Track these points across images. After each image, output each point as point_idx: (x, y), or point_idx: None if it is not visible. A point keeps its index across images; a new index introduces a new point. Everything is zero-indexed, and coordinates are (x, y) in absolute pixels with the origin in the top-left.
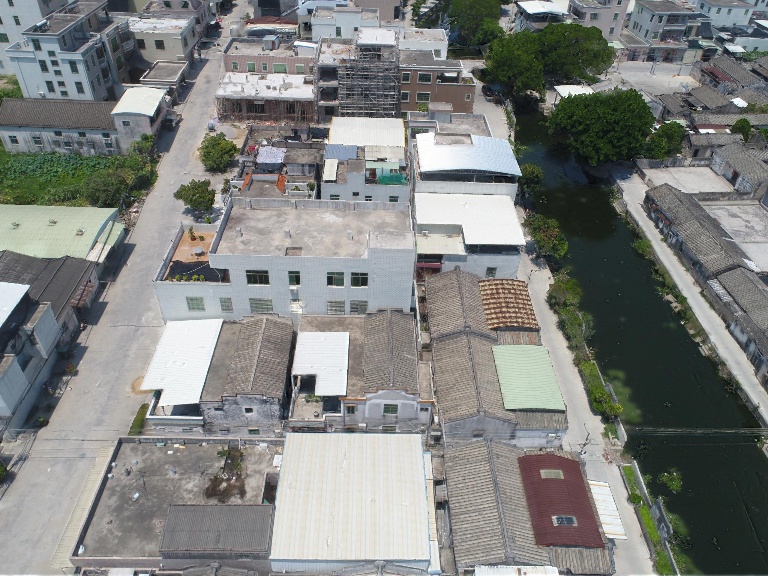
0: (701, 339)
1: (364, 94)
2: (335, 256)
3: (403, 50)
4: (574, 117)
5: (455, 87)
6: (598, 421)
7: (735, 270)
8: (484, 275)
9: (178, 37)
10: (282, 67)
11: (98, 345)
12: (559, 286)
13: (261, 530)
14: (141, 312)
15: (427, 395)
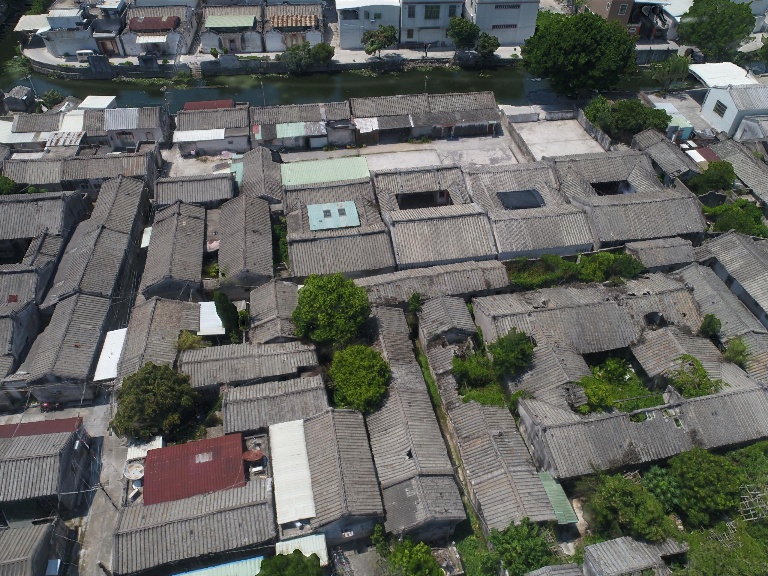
0: None
1: None
2: None
3: None
4: None
5: None
6: None
7: None
8: None
9: None
10: None
11: None
12: (322, 42)
13: None
14: None
15: None
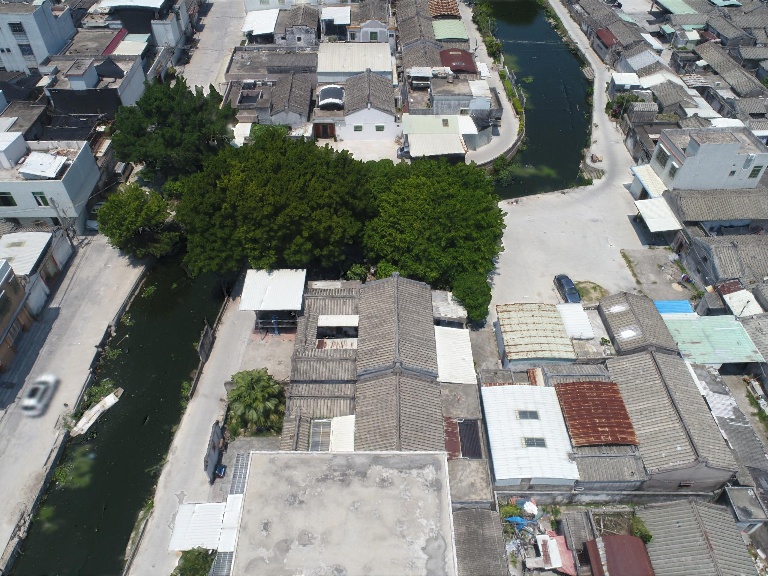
0: (564, 34)
1: None
2: None
3: None
4: None
5: None
6: (491, 59)
7: None
8: None
9: None
10: None
11: (206, 39)
12: (478, 5)
13: (312, 61)
14: (226, 27)
15: (393, 26)
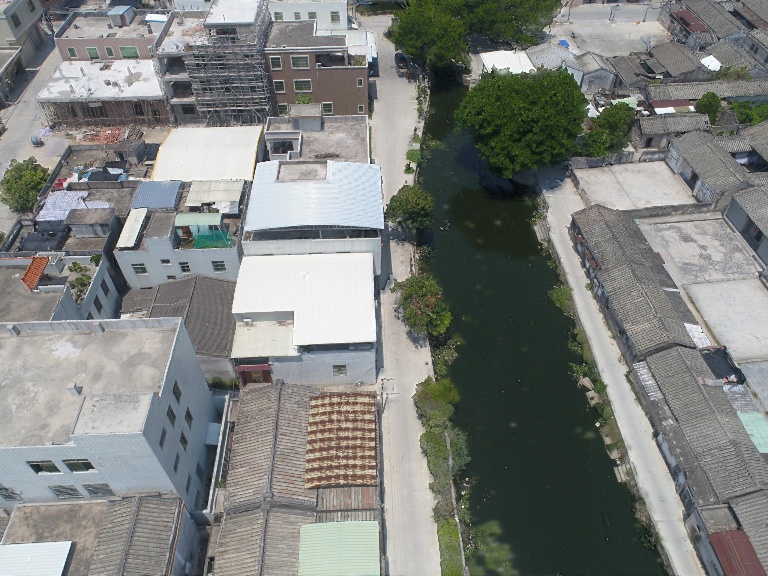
0: (618, 455)
1: (224, 88)
2: (41, 432)
3: (278, 22)
4: (482, 114)
5: (341, 71)
6: None
7: (670, 350)
8: (331, 373)
9: (1, 16)
10: (132, 51)
11: None
12: (425, 393)
13: None
14: None
15: None
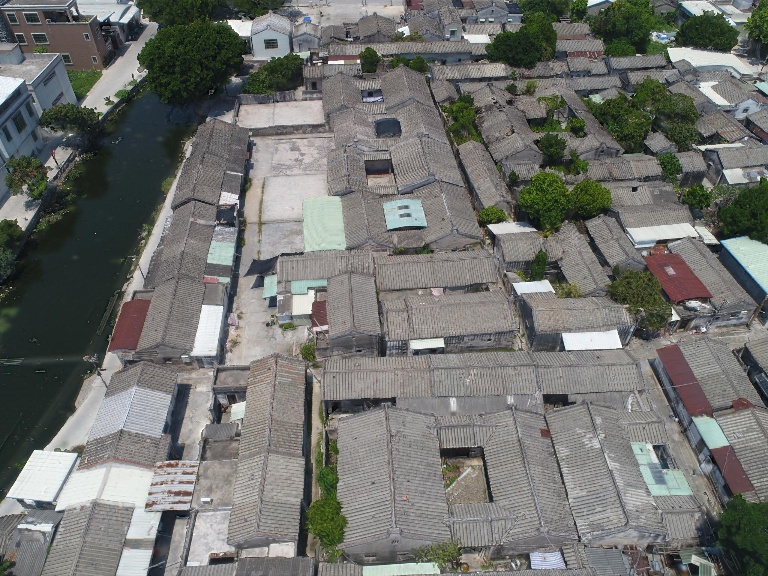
0: (131, 275)
1: None
2: None
3: None
4: None
5: (68, 26)
6: None
7: (188, 204)
8: None
9: None
10: None
11: None
12: None
13: None
14: None
15: None
